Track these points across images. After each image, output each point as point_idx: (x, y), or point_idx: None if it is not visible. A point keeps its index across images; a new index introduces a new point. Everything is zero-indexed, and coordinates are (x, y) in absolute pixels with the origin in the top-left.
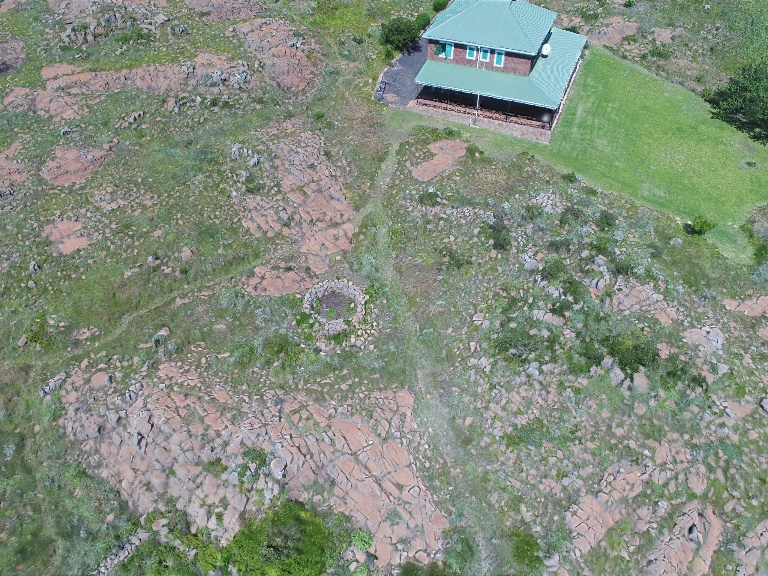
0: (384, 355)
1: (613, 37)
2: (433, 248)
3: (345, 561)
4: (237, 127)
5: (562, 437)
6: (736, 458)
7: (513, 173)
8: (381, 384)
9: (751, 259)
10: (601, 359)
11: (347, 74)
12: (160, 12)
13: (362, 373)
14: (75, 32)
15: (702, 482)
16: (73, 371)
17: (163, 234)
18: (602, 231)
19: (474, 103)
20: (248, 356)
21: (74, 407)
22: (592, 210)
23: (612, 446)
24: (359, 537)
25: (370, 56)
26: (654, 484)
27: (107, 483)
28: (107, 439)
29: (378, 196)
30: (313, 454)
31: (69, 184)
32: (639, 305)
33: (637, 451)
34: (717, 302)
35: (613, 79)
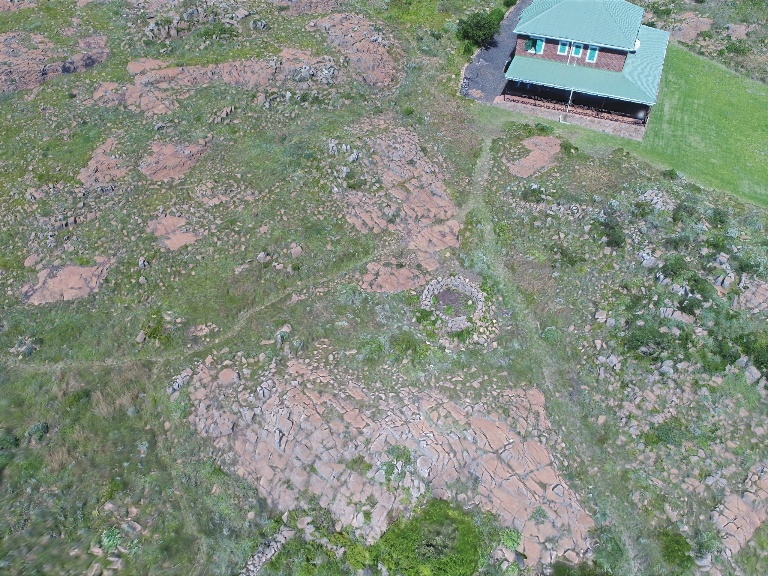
0: (509, 353)
1: (688, 33)
2: (542, 245)
3: (495, 560)
4: (329, 123)
5: (702, 436)
6: None
7: (612, 170)
8: (510, 382)
9: None
10: (737, 357)
11: (429, 69)
12: (240, 7)
13: (490, 371)
14: (158, 26)
15: None
16: (199, 368)
17: (269, 230)
18: (715, 228)
19: (564, 99)
20: (377, 353)
21: (205, 404)
22: (701, 207)
23: (753, 445)
24: (508, 536)
25: (449, 51)
26: None
27: (244, 480)
28: (241, 436)
29: (478, 192)
30: (456, 452)
31: (168, 179)
32: (766, 303)
33: None
34: None
35: (694, 75)
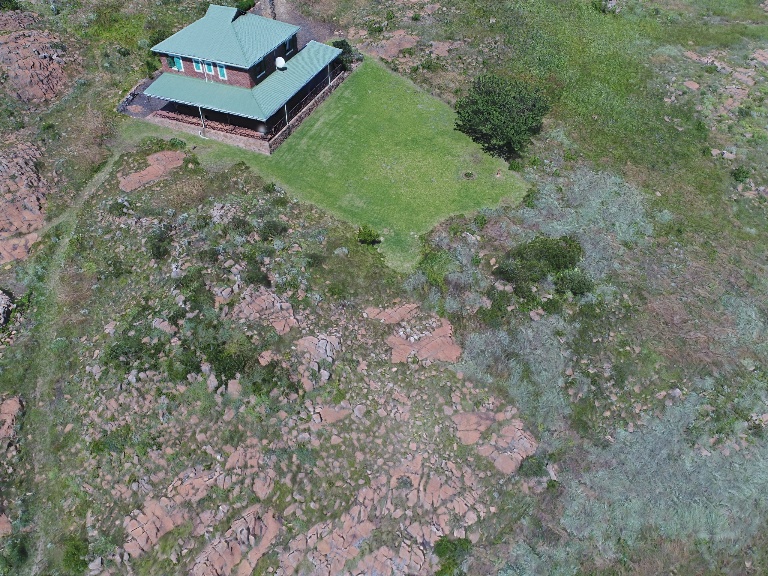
0: (6, 363)
1: (390, 50)
2: None
3: None
4: None
5: (142, 443)
6: (308, 463)
7: (215, 184)
8: None
9: (414, 268)
10: (194, 366)
11: (99, 86)
12: None
13: None
14: None
15: (268, 486)
16: None
17: None
18: (266, 241)
19: None
20: None
21: None
22: (266, 220)
23: (190, 452)
24: None
25: (131, 68)
26: (218, 489)
27: None
28: None
29: (77, 206)
30: None
31: None
32: (260, 313)
33: (213, 456)
34: (357, 310)
35: (372, 91)
